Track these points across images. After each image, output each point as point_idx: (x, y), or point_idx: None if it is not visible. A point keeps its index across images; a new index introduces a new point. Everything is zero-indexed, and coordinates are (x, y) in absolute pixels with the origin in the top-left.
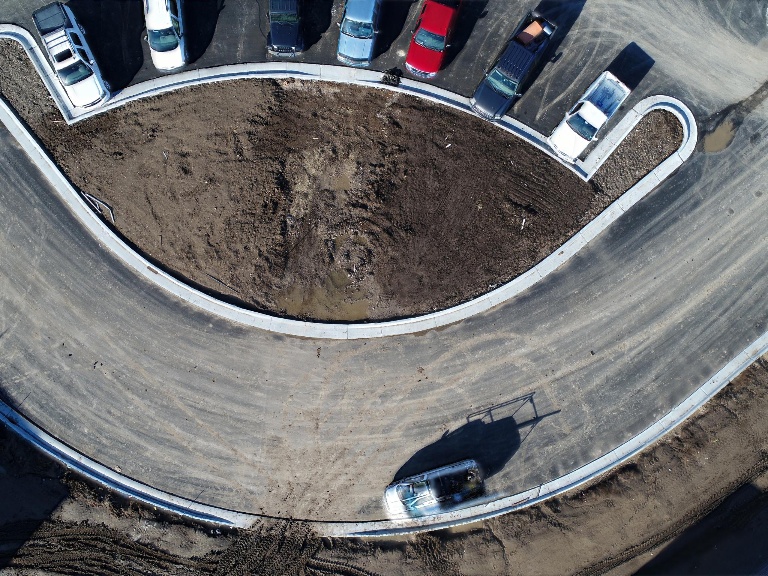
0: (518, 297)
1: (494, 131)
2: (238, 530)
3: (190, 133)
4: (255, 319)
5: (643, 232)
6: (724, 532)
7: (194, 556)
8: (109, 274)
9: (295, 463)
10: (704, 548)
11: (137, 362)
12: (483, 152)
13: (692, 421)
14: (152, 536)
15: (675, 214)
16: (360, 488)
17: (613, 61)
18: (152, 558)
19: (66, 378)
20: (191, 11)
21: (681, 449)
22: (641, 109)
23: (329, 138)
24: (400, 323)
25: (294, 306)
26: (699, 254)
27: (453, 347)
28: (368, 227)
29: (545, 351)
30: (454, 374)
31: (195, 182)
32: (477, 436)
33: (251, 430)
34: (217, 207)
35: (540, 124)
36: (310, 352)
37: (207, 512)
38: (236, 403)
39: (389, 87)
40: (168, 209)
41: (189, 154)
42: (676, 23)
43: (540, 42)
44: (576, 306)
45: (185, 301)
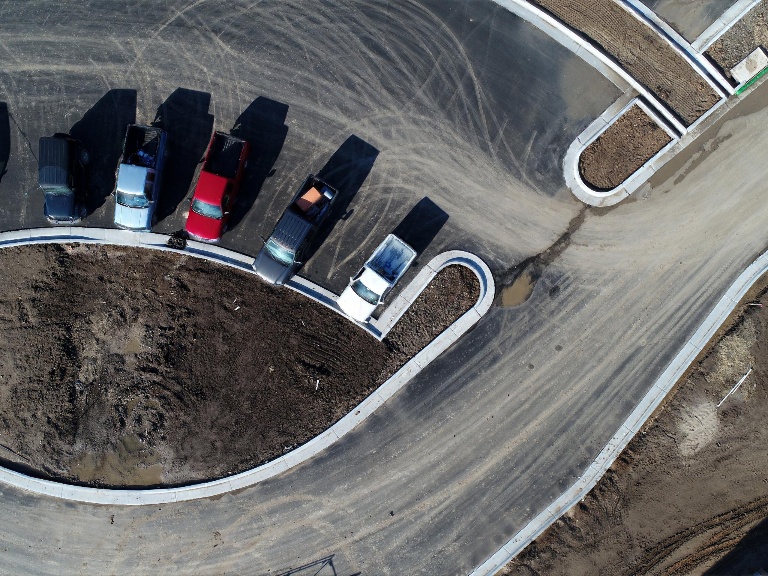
0: (315, 458)
1: (284, 292)
2: None
3: None
4: (46, 487)
5: (441, 389)
6: None
7: None
8: None
9: None
10: None
11: None
12: (273, 314)
13: None
14: None
15: (474, 370)
16: None
17: (406, 217)
18: None
19: None
20: None
21: None
22: (436, 265)
23: (117, 302)
24: (194, 488)
25: (86, 472)
26: (499, 410)
27: (250, 510)
28: (159, 391)
29: (344, 512)
30: (251, 538)
31: None
32: None
33: None
34: (3, 375)
35: (332, 283)
36: (103, 519)
37: None
38: (29, 572)
39: (175, 250)
40: None
41: None
42: (470, 176)
43: (322, 206)
44: (374, 466)
45: None
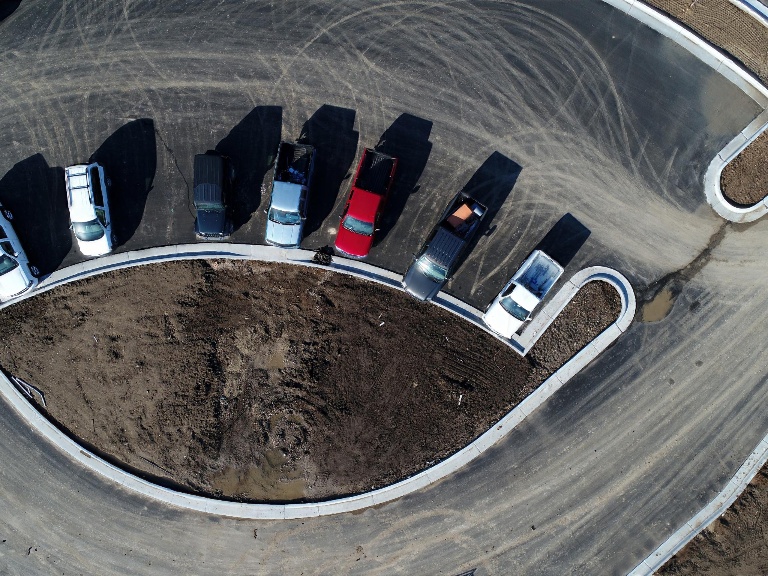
0: (457, 473)
1: (428, 308)
2: None
3: (120, 316)
4: (190, 501)
5: (582, 404)
6: None
7: None
8: (42, 458)
9: None
10: None
11: (72, 546)
12: (417, 329)
13: None
14: None
15: (615, 385)
16: None
17: (548, 233)
18: None
19: (0, 564)
20: (119, 193)
21: None
22: (578, 281)
23: (261, 317)
24: (337, 502)
25: (230, 486)
26: (640, 425)
27: (392, 525)
28: (303, 406)
29: (485, 527)
30: (393, 552)
31: (126, 366)
32: None
33: None
34: (149, 390)
35: (475, 299)
36: (247, 533)
37: None
38: None
39: (321, 266)
40: (100, 393)
41: (120, 337)
42: (612, 193)
43: (471, 223)
44: (516, 481)
45: (119, 484)
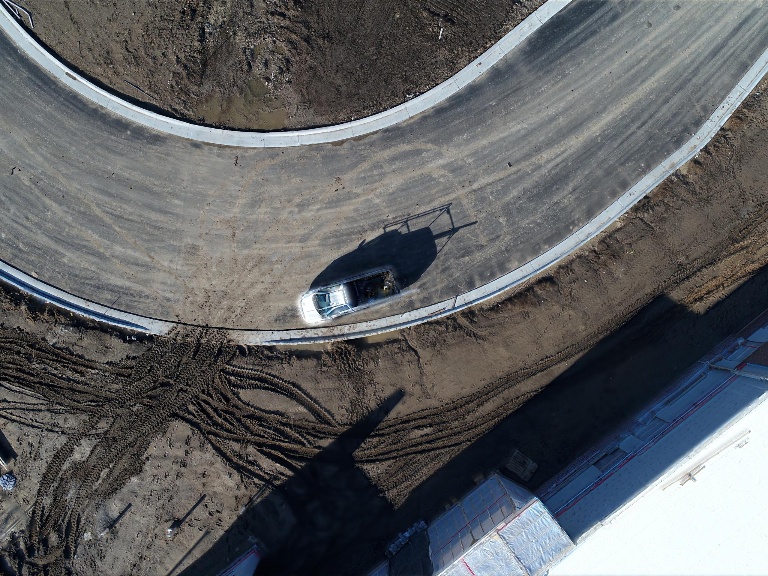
0: (436, 108)
1: None
2: (154, 337)
3: None
4: (173, 126)
5: (561, 44)
6: (639, 343)
7: (109, 361)
8: (28, 80)
9: (211, 271)
10: (619, 359)
11: (55, 168)
12: None
13: (609, 234)
14: (67, 341)
15: (593, 27)
16: (276, 297)
17: None
18: (67, 362)
19: None
20: None
21: (597, 261)
22: None
23: None
24: (317, 132)
25: (212, 115)
26: (617, 67)
27: (370, 157)
28: (286, 35)
29: (462, 162)
30: (371, 184)
31: None
32: (393, 246)
33: (168, 237)
34: (135, 13)
35: None
36: (227, 160)
37: (123, 318)
38: (153, 210)
39: None
40: (86, 14)
41: None
42: None
43: None
44: (493, 118)
45: (103, 108)
